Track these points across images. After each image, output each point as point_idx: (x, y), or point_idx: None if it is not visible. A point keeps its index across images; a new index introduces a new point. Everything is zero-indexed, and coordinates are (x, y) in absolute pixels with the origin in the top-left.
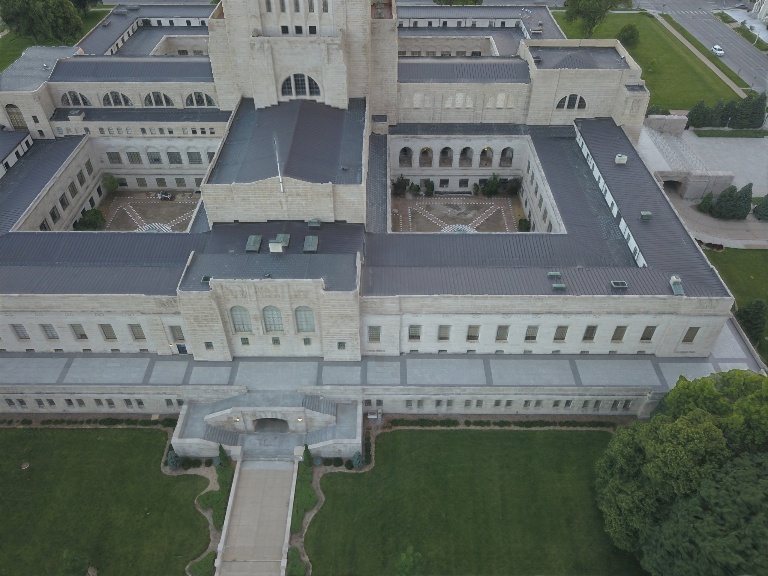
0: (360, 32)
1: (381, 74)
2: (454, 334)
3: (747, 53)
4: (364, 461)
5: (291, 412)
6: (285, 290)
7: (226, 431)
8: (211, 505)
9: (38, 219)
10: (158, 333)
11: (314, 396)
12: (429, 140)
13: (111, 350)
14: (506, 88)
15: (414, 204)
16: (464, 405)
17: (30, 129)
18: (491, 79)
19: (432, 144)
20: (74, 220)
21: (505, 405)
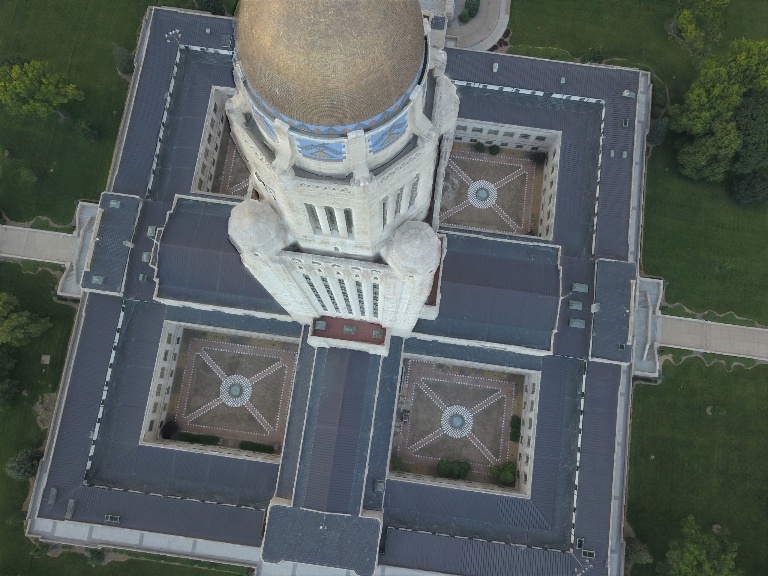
0: None
1: None
2: None
3: None
4: None
5: None
6: None
7: None
8: None
9: None
10: None
11: None
12: None
13: None
14: None
15: None
16: None
17: None
18: None
19: None
20: None
21: None
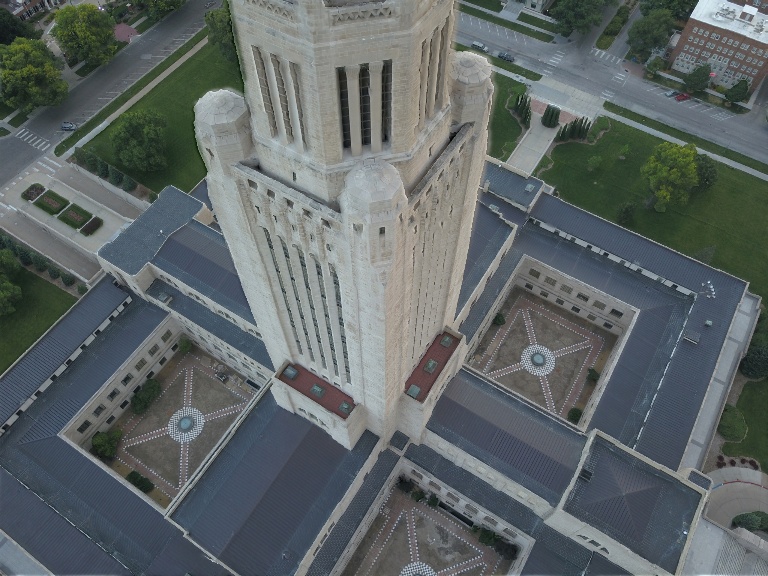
0: (377, 413)
1: (406, 421)
2: None
3: None
4: None
5: None
6: None
7: None
8: None
9: (92, 409)
10: None
11: None
12: None
13: None
14: (529, 494)
15: (411, 508)
16: None
17: (132, 289)
18: (521, 473)
19: None
20: (136, 386)
21: None
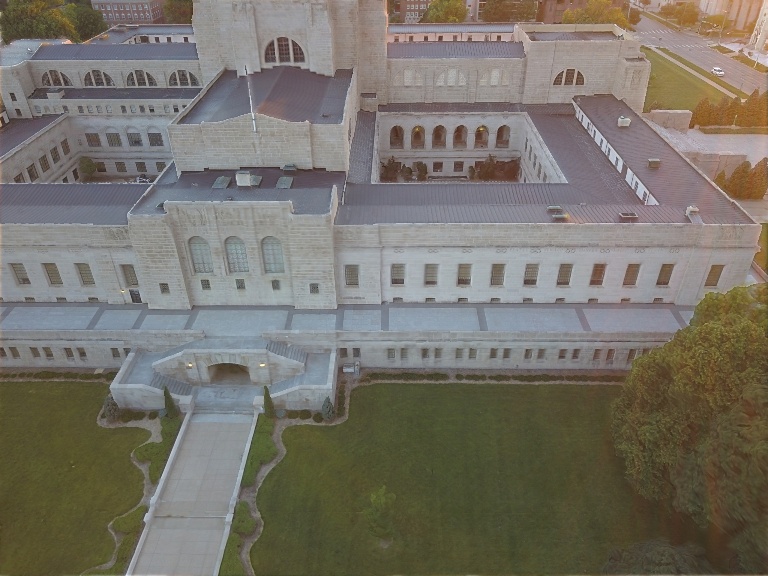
0: None
1: (370, 47)
2: (442, 276)
3: (748, 74)
4: (336, 413)
5: (252, 355)
6: (249, 215)
7: (177, 382)
8: (149, 457)
9: None
10: (108, 274)
11: (281, 343)
12: (421, 117)
13: (56, 299)
14: (500, 63)
15: None
16: (455, 356)
17: (7, 107)
18: (484, 56)
19: (424, 122)
20: None
21: (503, 356)
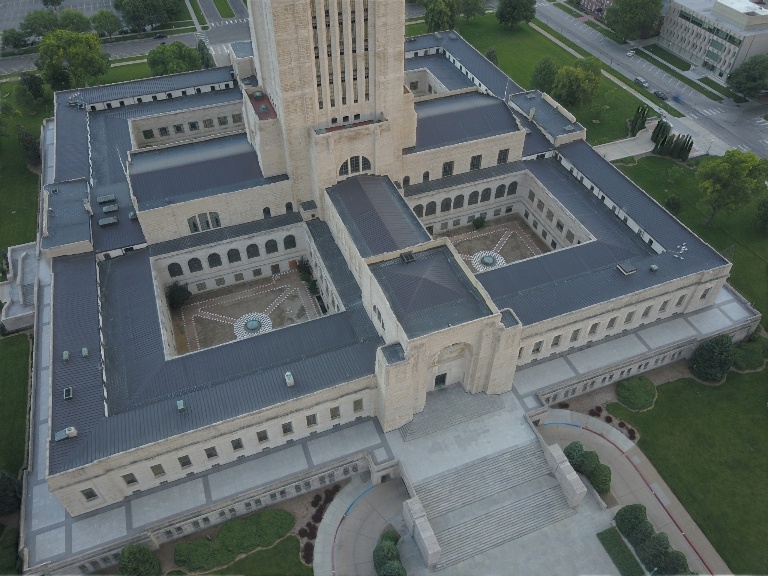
0: None
1: None
2: None
3: None
4: (4, 333)
5: None
6: None
7: None
8: None
9: (159, 124)
10: None
11: None
12: None
13: None
14: (357, 256)
15: (295, 287)
16: None
17: (237, 79)
18: (364, 241)
19: None
20: None
21: None
